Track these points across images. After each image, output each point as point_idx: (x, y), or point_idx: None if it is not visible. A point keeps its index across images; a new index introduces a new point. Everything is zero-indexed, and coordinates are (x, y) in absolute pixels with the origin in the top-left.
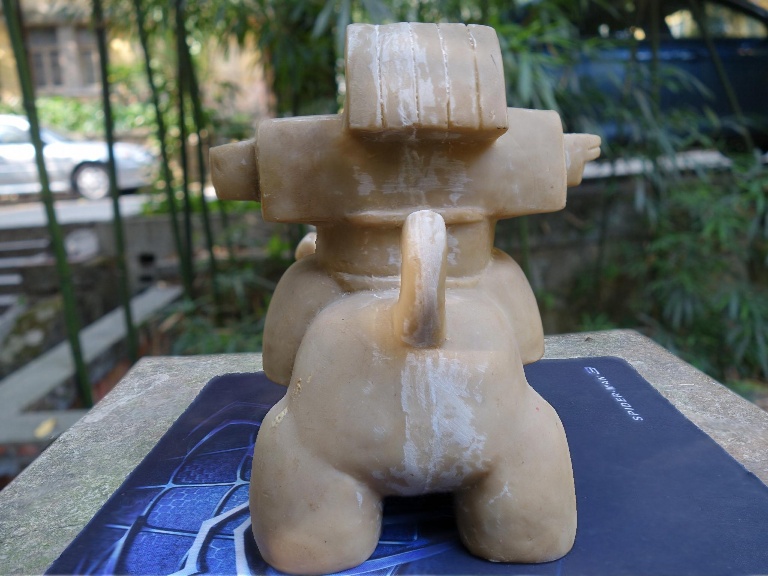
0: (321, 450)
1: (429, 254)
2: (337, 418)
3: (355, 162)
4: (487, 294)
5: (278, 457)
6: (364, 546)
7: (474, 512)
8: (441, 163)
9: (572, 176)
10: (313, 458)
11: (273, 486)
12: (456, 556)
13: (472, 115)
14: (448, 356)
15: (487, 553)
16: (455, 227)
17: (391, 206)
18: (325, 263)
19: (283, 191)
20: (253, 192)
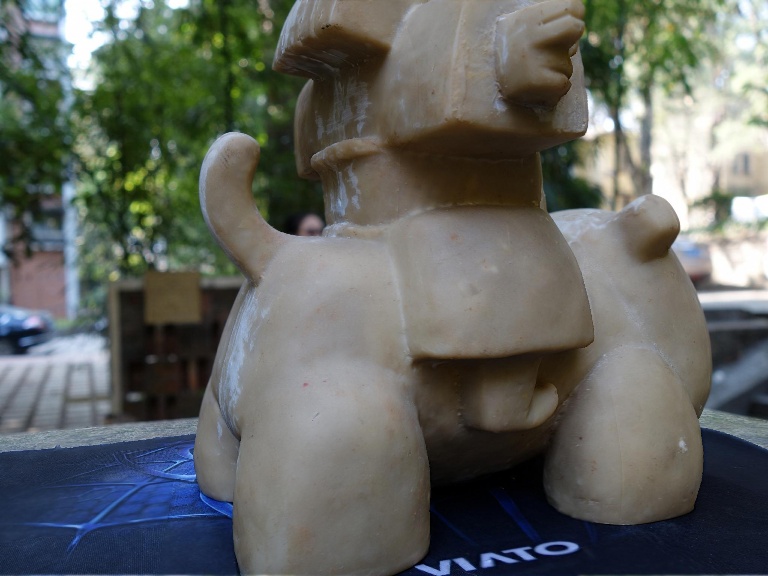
0: None
1: None
2: None
3: (316, 106)
4: (388, 249)
5: None
6: (223, 483)
7: None
8: (353, 90)
9: (515, 74)
10: None
11: None
12: None
13: (309, 22)
14: (256, 295)
15: None
16: (355, 163)
17: None
18: None
19: (297, 146)
20: None
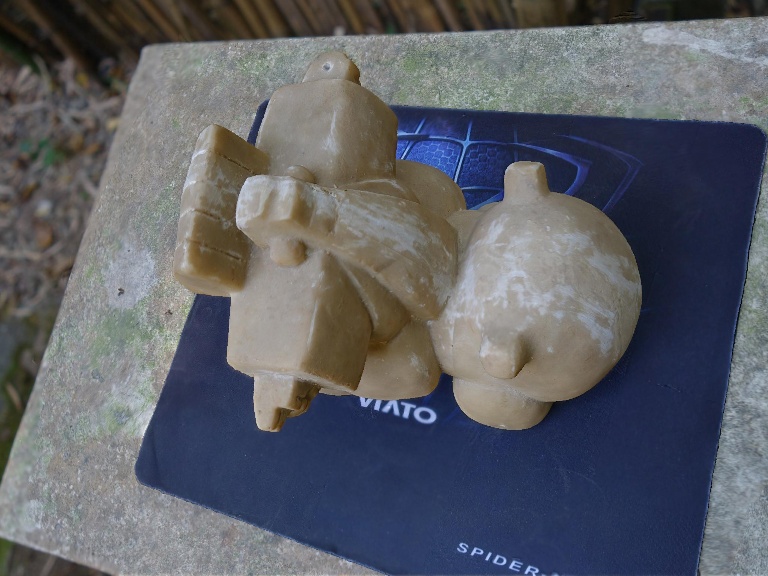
0: None
1: None
2: None
3: None
4: None
5: None
6: None
7: None
8: None
9: None
10: None
11: None
12: None
13: None
14: None
15: None
16: None
17: None
18: None
19: None
20: None
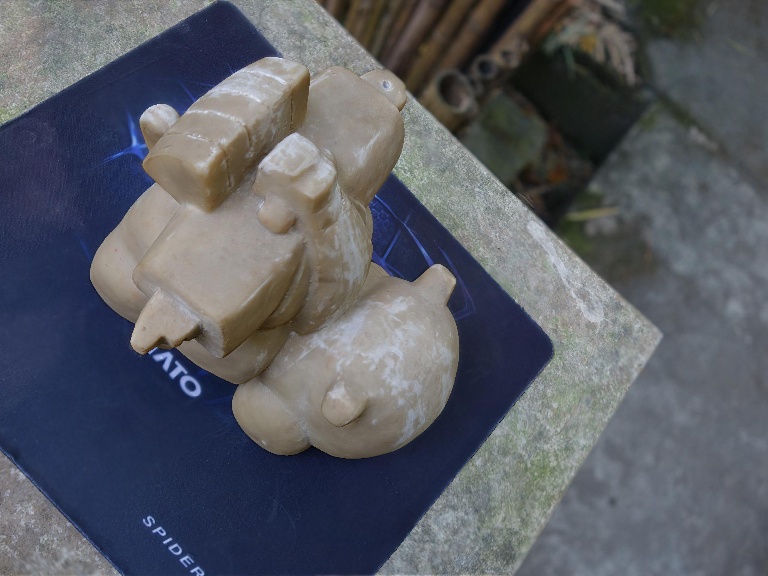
0: None
1: None
2: None
3: None
4: None
5: None
6: None
7: None
8: None
9: None
10: None
11: None
12: None
13: None
14: None
15: None
16: None
17: None
18: None
19: None
20: None
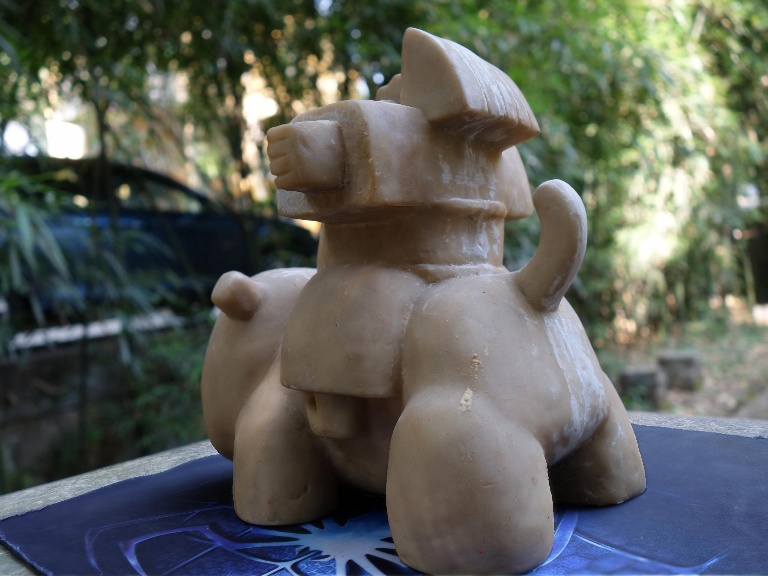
0: (523, 419)
1: (583, 211)
2: (526, 383)
3: (439, 150)
4: None
5: (489, 438)
6: None
7: (600, 461)
8: (483, 163)
9: None
10: (520, 429)
11: (496, 471)
12: (592, 512)
13: (527, 117)
14: (564, 317)
15: (616, 496)
16: (497, 220)
17: (461, 196)
18: (395, 258)
19: (392, 171)
20: (339, 176)
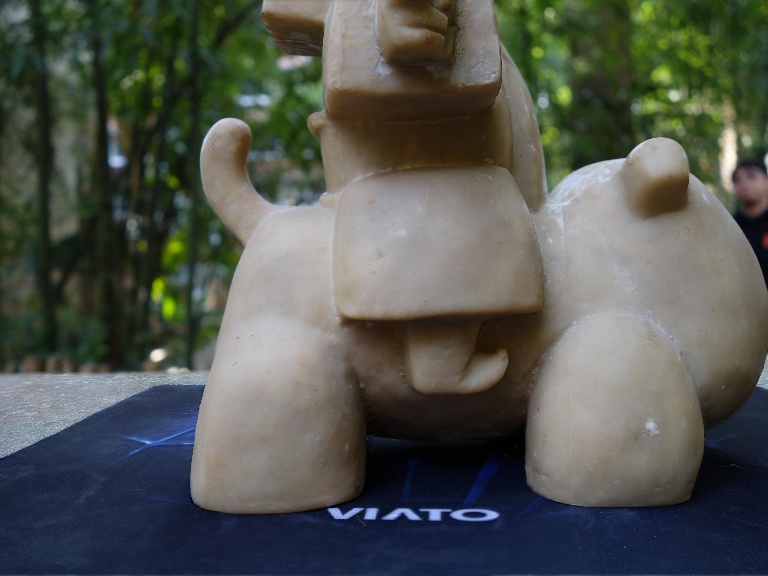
0: None
1: None
2: None
3: None
4: None
5: None
6: None
7: None
8: None
9: (384, 36)
10: None
11: None
12: None
13: None
14: None
15: None
16: None
17: None
18: None
19: None
20: None
